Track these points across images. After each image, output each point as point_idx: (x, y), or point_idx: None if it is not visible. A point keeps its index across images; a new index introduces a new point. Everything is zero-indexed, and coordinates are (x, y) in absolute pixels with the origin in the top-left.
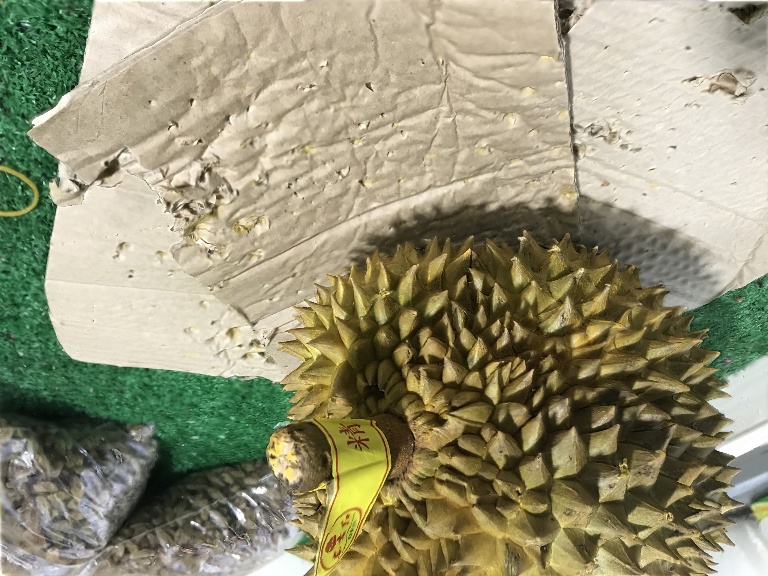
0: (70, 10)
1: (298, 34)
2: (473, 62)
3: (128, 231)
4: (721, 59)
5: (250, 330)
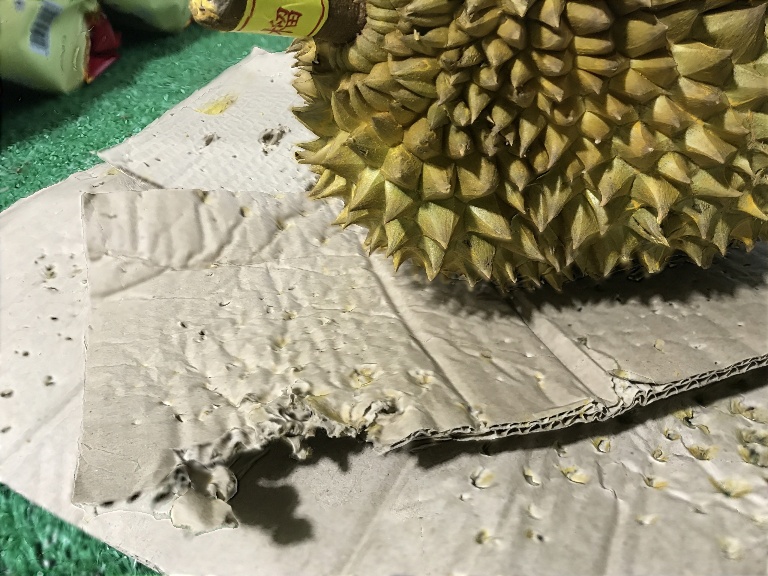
0: (98, 573)
1: (140, 336)
2: (210, 243)
3: (421, 569)
4: (247, 143)
5: (717, 465)
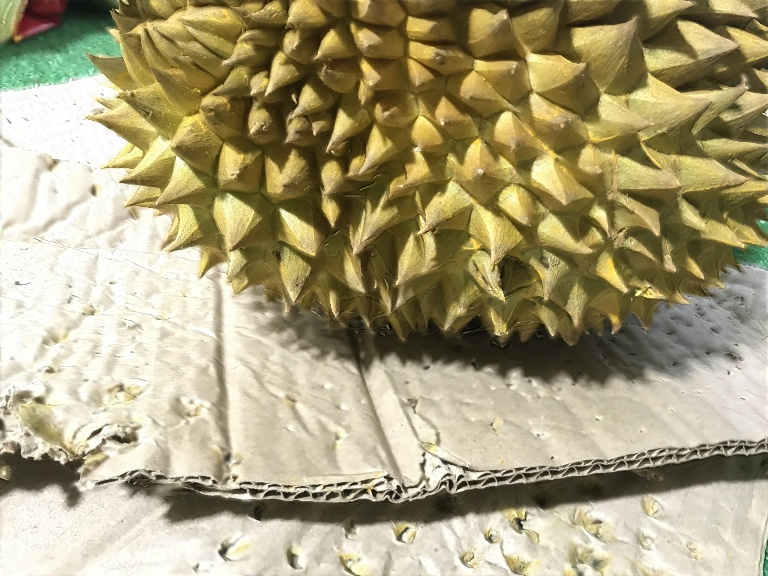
0: None
1: None
2: (40, 215)
3: None
4: None
5: None
